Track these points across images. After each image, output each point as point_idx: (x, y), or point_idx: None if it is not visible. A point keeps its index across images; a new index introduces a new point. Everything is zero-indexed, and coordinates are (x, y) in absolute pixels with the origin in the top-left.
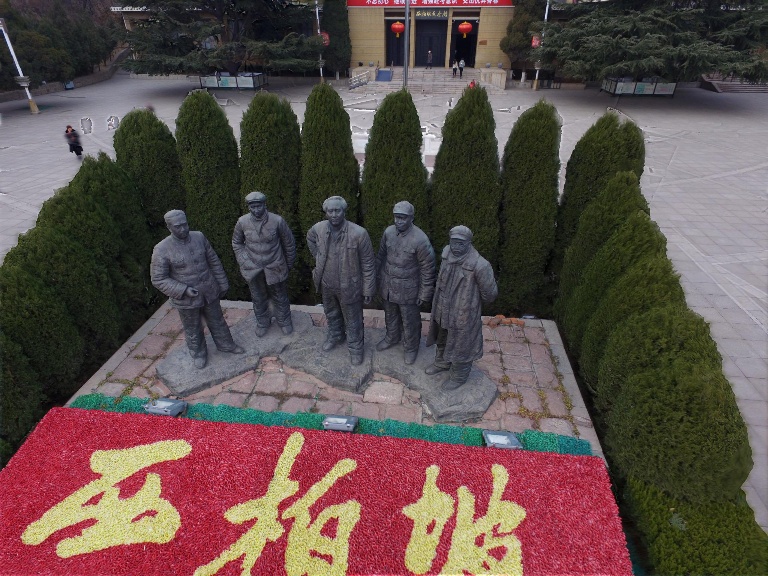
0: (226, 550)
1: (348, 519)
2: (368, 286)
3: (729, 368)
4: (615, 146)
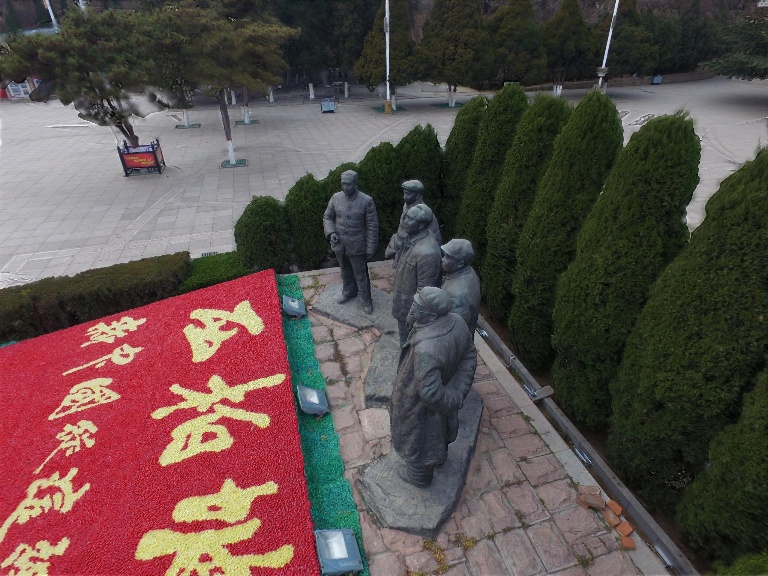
0: (189, 390)
1: (217, 444)
2: (411, 312)
3: None
4: None
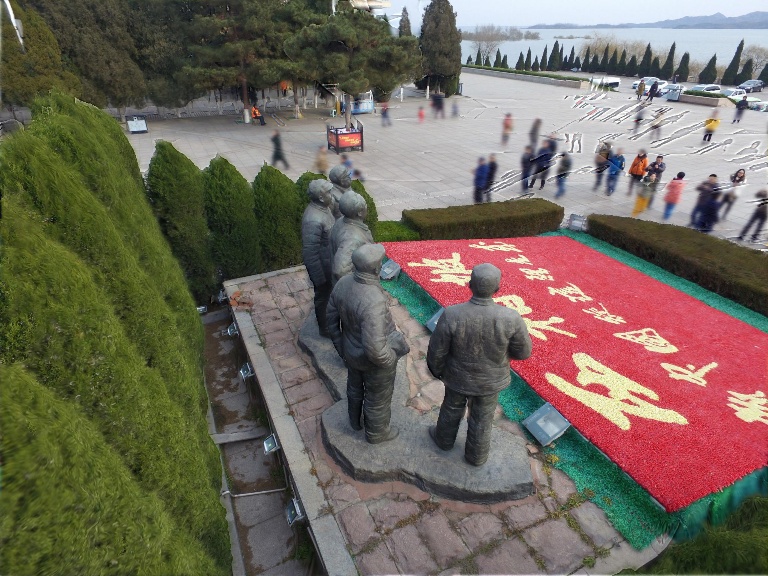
0: None
1: None
2: None
3: None
4: None
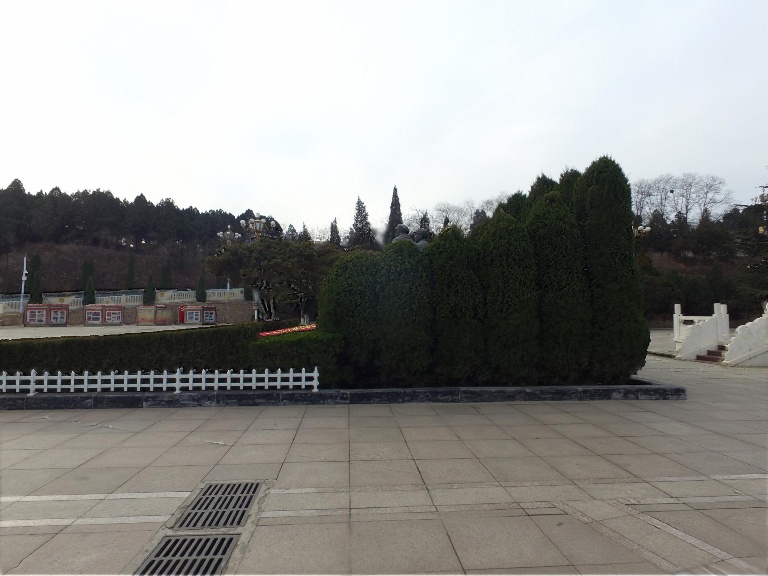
0: None
1: None
2: None
3: (629, 431)
4: (580, 181)
